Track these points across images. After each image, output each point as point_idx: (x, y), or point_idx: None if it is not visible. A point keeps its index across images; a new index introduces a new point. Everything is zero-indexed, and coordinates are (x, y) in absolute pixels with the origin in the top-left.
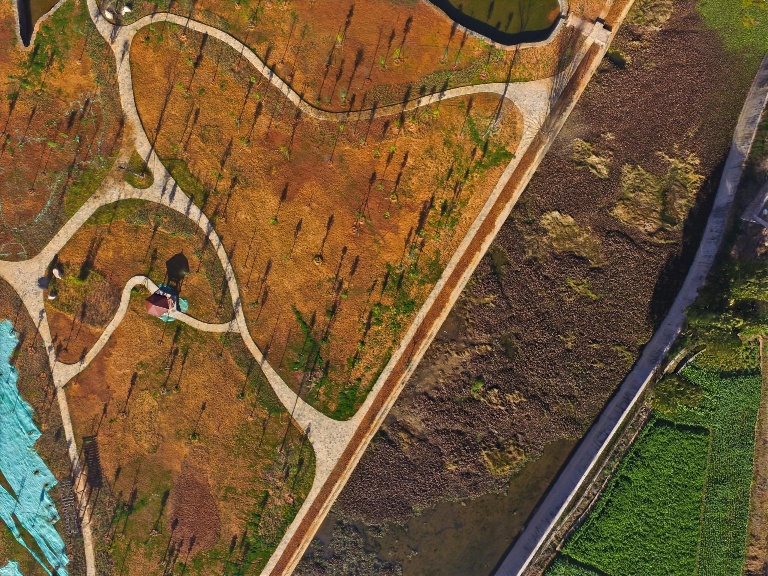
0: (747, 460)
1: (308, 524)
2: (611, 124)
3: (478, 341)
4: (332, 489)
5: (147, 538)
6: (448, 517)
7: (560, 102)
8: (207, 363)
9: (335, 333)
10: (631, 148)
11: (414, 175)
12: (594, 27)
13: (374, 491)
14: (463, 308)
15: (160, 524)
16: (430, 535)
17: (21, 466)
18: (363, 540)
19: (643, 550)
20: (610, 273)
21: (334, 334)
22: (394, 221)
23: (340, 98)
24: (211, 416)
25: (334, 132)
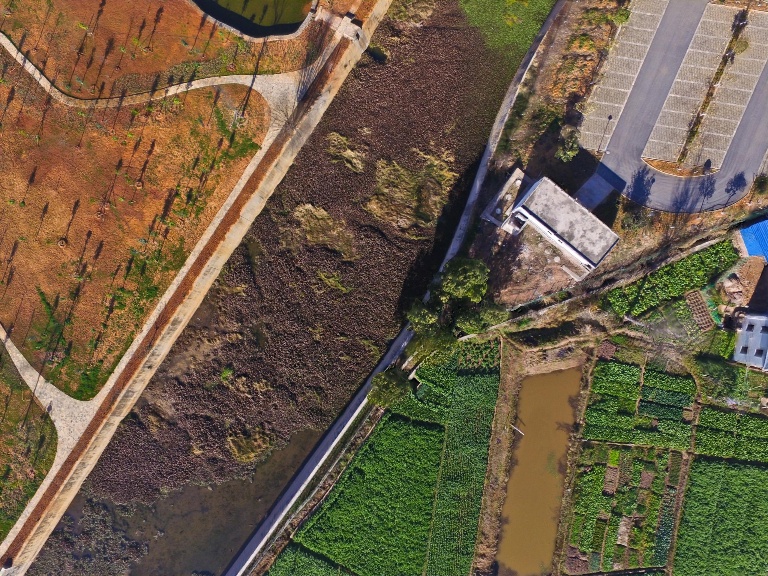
0: (480, 458)
1: (49, 499)
2: (368, 119)
3: (230, 329)
4: (73, 467)
5: None
6: (195, 500)
7: (308, 95)
8: None
9: (78, 315)
10: (387, 144)
11: (160, 163)
12: (342, 21)
13: (122, 471)
14: (216, 296)
15: None
16: (177, 517)
17: None
18: (112, 518)
19: (373, 542)
20: (360, 267)
21: (77, 316)
22: (139, 208)
23: (90, 85)
24: None
25: (83, 118)
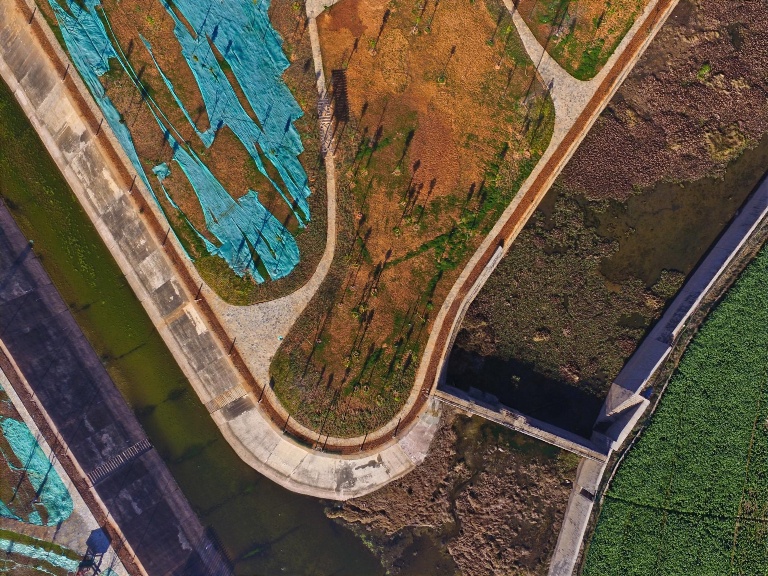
0: None
1: (543, 181)
2: None
3: (707, 28)
4: (568, 148)
5: (389, 177)
6: (666, 198)
7: None
8: (460, 7)
9: None
10: None
11: None
12: None
13: (599, 165)
14: None
15: (402, 164)
16: (648, 214)
17: (268, 95)
18: (584, 214)
19: None
20: None
21: None
22: None
23: None
24: (460, 61)
25: None
